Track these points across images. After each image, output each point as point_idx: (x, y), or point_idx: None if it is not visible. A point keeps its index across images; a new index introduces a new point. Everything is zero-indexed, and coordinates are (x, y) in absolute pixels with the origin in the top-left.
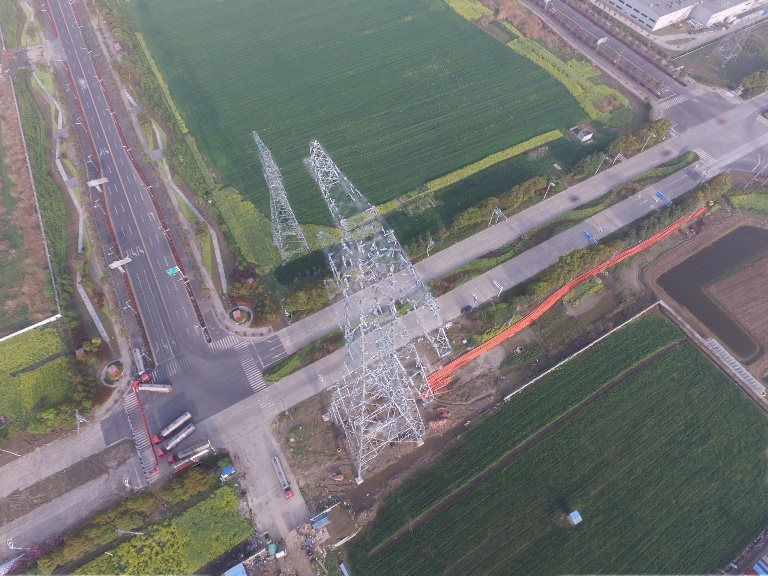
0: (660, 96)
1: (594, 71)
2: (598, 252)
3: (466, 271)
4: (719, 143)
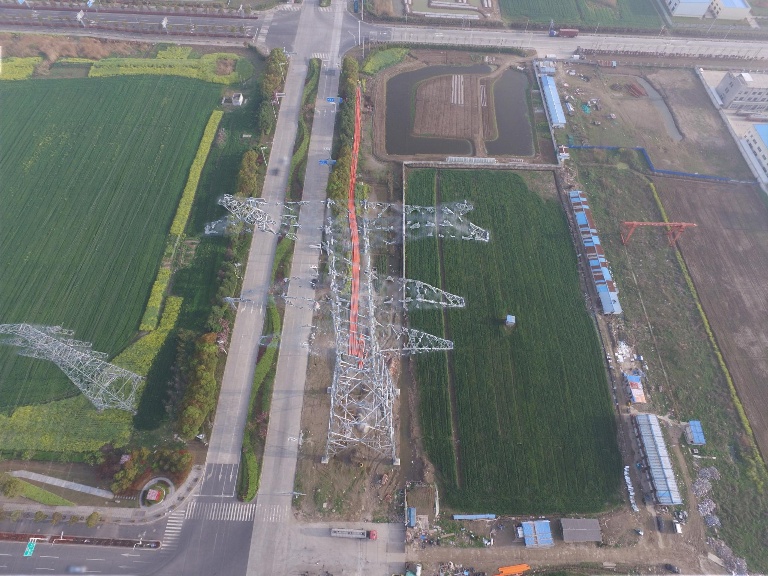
0: (250, 36)
1: (185, 50)
2: (343, 165)
3: (281, 261)
4: (319, 41)
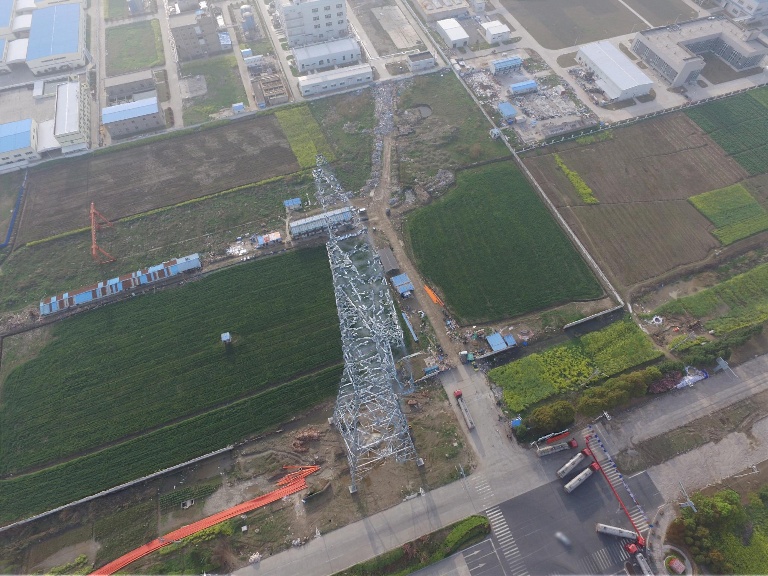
0: None
1: None
2: None
3: None
4: None
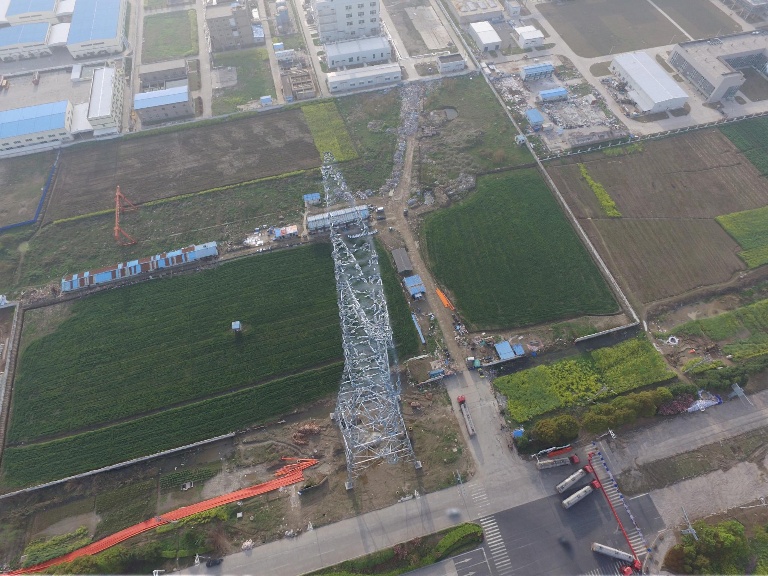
0: None
1: None
2: None
3: None
4: None
